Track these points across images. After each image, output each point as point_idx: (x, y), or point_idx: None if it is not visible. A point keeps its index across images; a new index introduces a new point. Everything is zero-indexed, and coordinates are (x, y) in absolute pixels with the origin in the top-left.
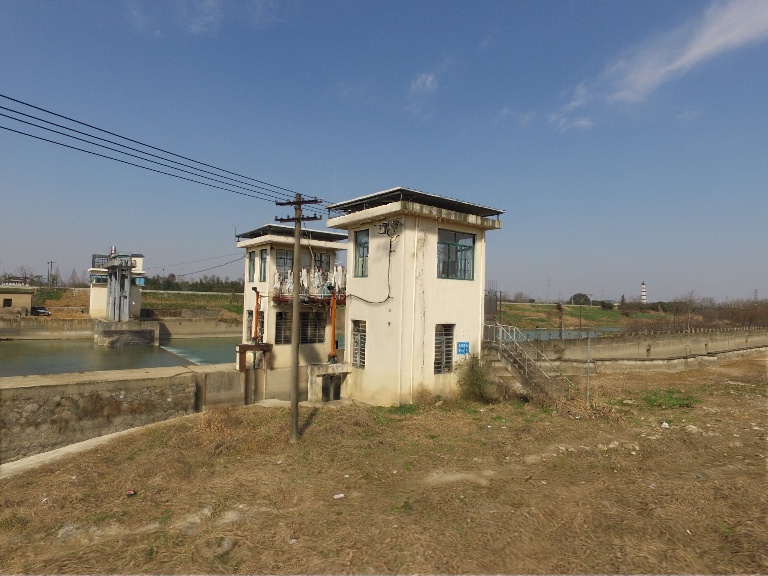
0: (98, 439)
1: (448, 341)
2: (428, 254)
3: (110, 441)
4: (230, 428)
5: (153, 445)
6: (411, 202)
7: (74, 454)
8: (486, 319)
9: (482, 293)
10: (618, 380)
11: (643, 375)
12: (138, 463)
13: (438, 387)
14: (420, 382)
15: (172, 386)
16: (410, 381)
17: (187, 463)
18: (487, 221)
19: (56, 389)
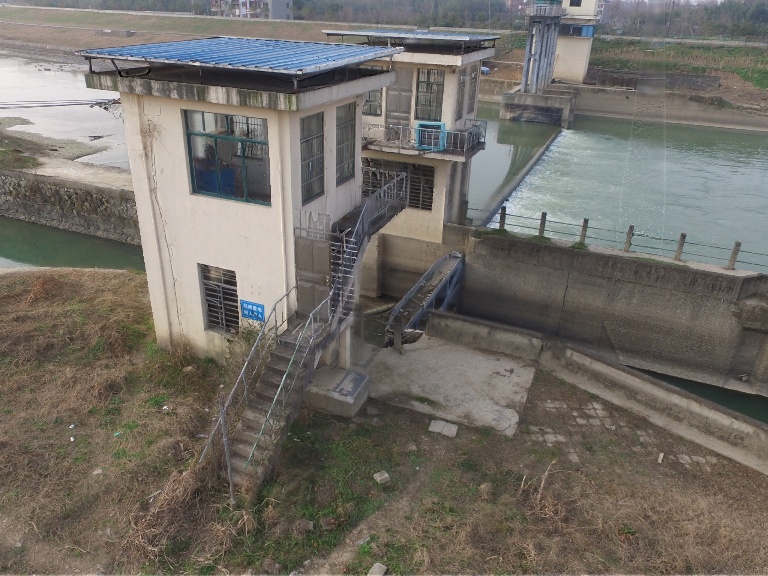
0: (8, 269)
1: (233, 292)
2: (169, 154)
3: (3, 274)
4: (48, 297)
5: None
6: (97, 75)
7: None
8: (304, 279)
9: (288, 232)
10: None
11: None
12: None
13: (214, 348)
14: (182, 331)
15: None
16: (167, 325)
17: None
18: (257, 97)
19: None
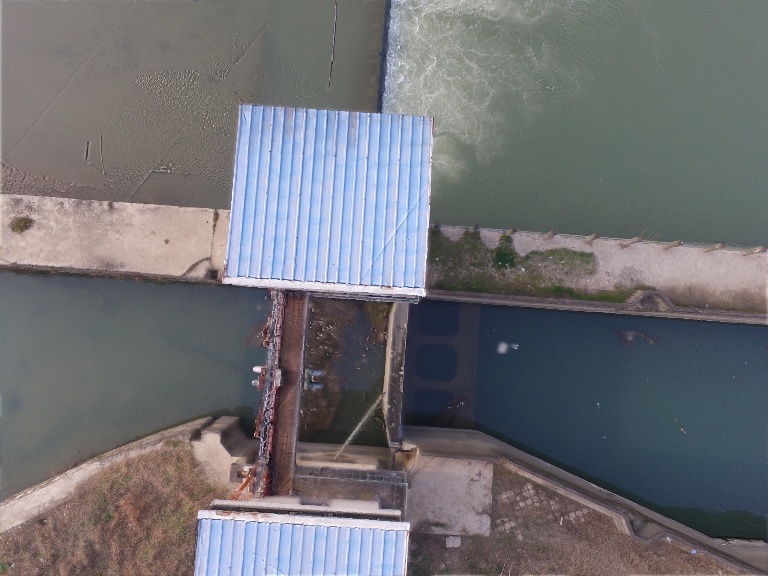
0: (70, 481)
1: None
2: None
3: (75, 490)
4: None
5: (89, 522)
6: None
7: (54, 505)
8: None
9: None
10: (628, 568)
11: (692, 575)
12: (64, 573)
13: None
14: None
15: (187, 278)
16: None
17: (93, 567)
18: None
19: (81, 270)
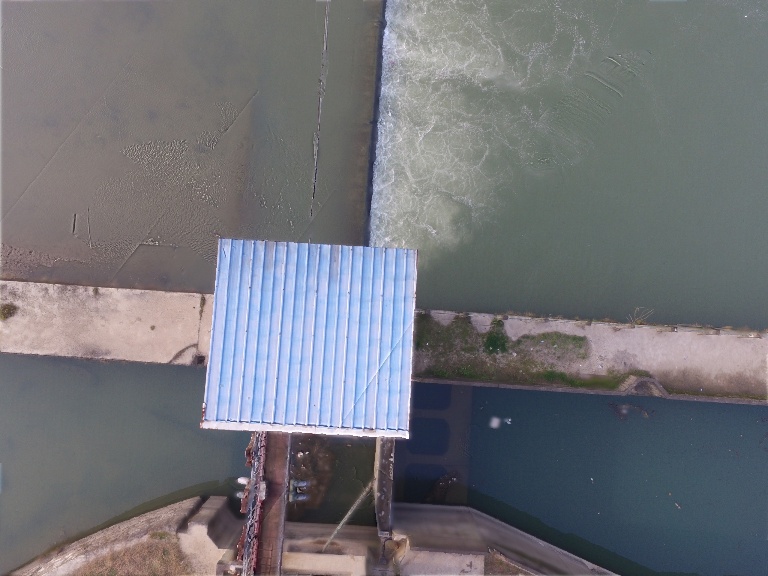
0: (55, 575)
1: None
2: None
3: None
4: None
5: None
6: None
7: None
8: None
9: None
10: None
11: None
12: None
13: None
14: None
15: None
16: None
17: None
18: None
19: None
